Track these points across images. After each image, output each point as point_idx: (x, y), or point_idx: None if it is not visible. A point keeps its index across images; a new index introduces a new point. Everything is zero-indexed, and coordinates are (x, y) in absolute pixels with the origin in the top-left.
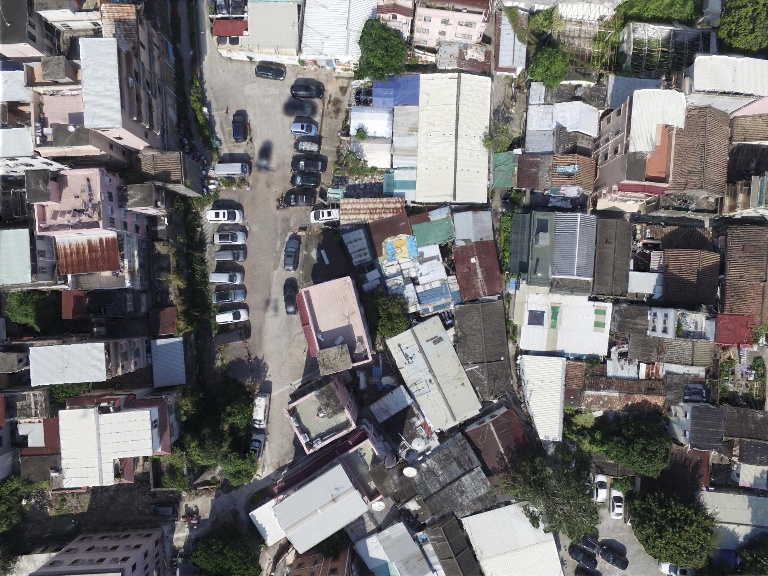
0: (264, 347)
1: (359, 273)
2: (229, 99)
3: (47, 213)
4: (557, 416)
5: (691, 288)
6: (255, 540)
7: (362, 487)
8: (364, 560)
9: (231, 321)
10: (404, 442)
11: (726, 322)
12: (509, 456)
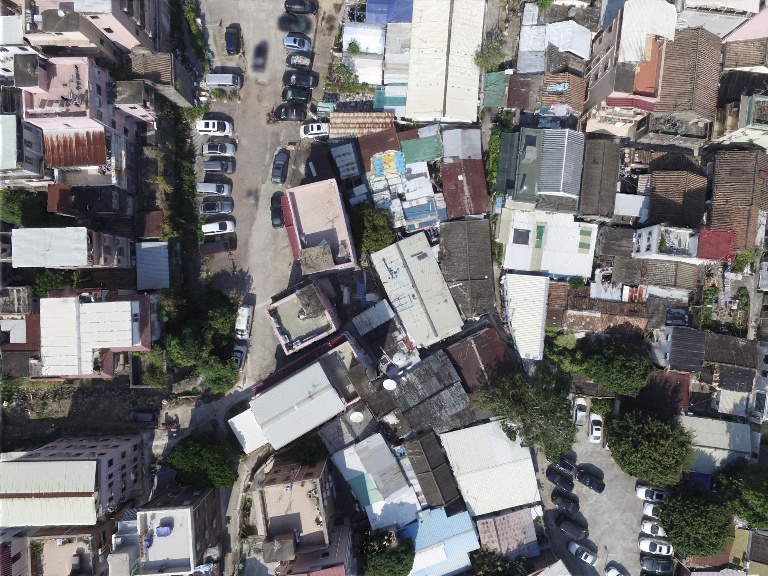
0: (249, 260)
1: (346, 189)
2: (223, 12)
3: (35, 101)
4: (538, 334)
5: (677, 209)
6: (233, 449)
7: (340, 390)
8: (341, 471)
9: (217, 231)
10: (385, 356)
11: (709, 236)
12: (489, 373)
